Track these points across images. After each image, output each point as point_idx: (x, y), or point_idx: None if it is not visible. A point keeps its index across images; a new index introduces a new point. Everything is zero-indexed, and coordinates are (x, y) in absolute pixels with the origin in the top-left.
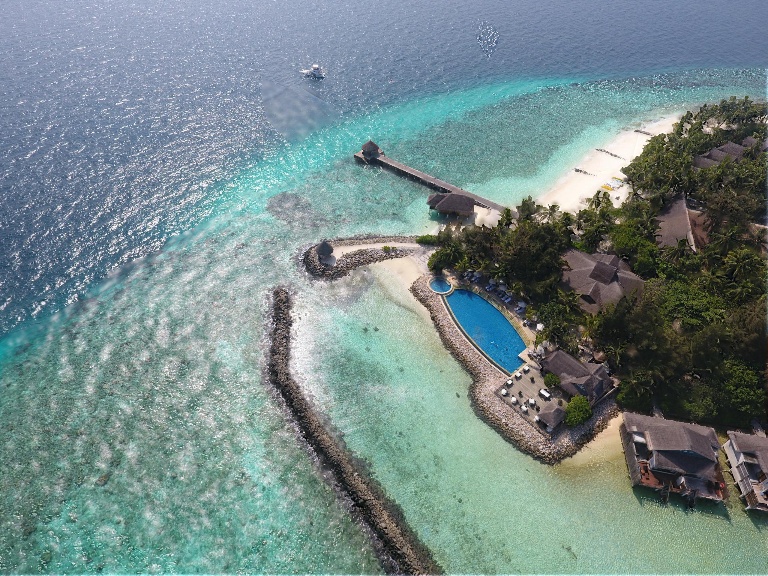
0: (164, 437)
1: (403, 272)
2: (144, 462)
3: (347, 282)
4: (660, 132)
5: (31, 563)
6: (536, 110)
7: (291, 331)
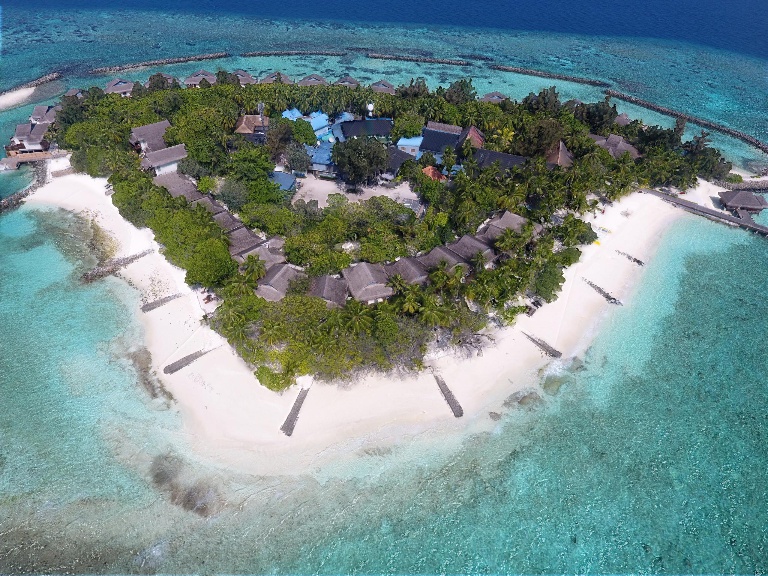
0: (763, 126)
1: (731, 170)
2: (760, 122)
3: (759, 167)
4: (518, 351)
5: (760, 110)
6: (765, 434)
7: (760, 149)
